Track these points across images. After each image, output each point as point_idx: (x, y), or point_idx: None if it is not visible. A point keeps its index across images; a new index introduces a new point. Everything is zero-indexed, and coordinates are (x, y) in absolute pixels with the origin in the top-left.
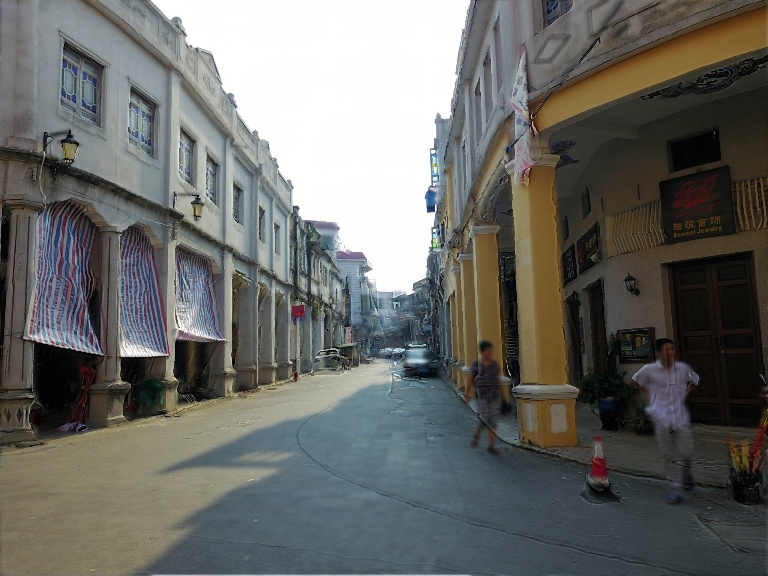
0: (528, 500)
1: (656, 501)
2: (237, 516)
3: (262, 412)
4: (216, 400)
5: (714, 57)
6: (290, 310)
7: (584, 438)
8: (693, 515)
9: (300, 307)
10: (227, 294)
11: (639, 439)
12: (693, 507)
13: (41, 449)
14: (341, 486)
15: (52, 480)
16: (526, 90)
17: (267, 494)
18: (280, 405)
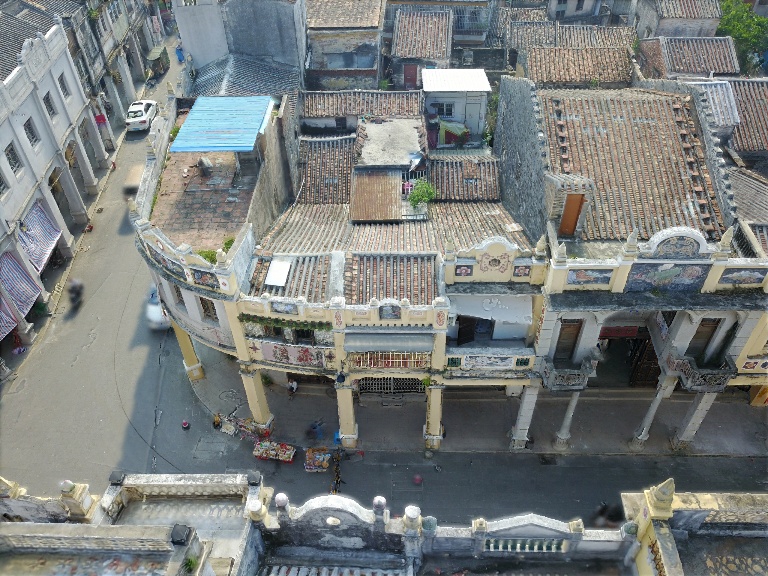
0: (169, 431)
1: (198, 428)
2: (100, 450)
3: (98, 305)
4: (70, 270)
5: (202, 342)
6: (94, 119)
7: (212, 364)
8: (199, 437)
9: (101, 116)
10: (52, 205)
11: (227, 366)
12: (204, 431)
13: (21, 384)
14: (125, 424)
15: (44, 426)
16: (160, 302)
17: (106, 434)
18: (106, 284)
